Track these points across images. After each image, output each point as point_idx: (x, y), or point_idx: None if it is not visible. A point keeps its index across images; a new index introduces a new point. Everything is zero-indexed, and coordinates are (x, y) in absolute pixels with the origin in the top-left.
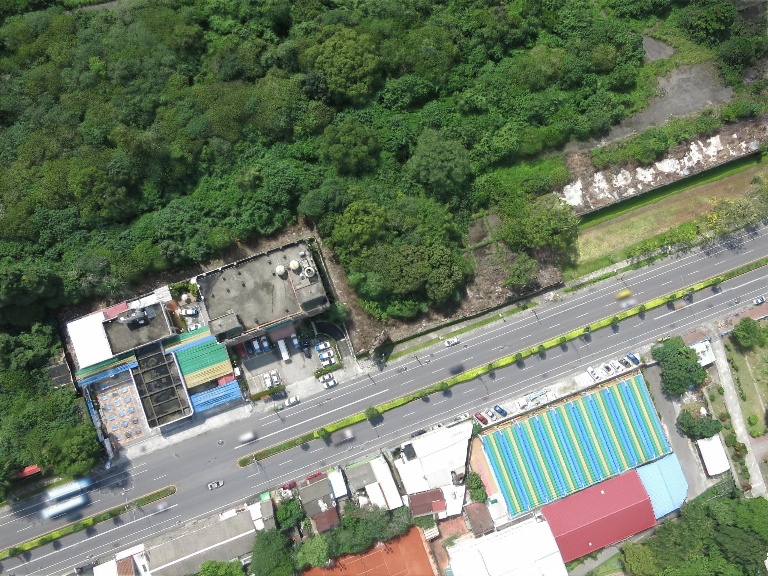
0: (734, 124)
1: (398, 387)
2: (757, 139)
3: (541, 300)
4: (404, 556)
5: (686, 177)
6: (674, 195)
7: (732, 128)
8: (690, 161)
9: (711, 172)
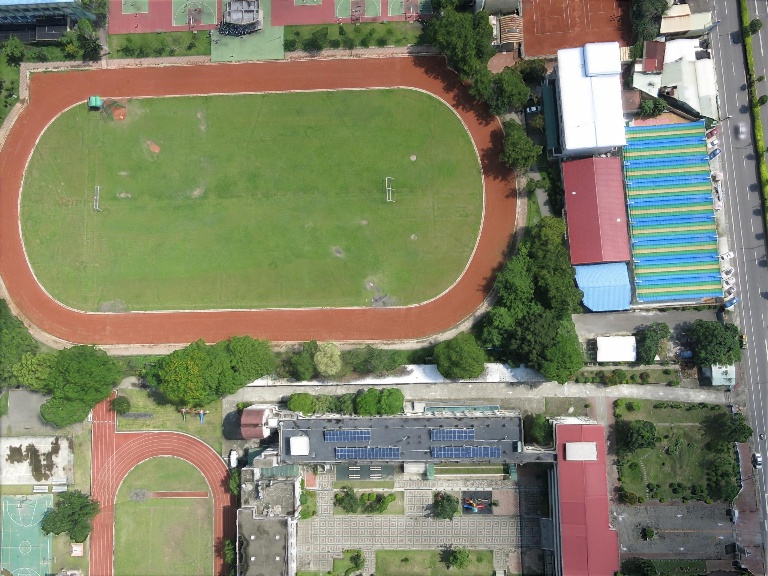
0: None
1: (763, 65)
2: None
3: None
4: (604, 30)
5: None
6: None
7: None
8: None
9: None
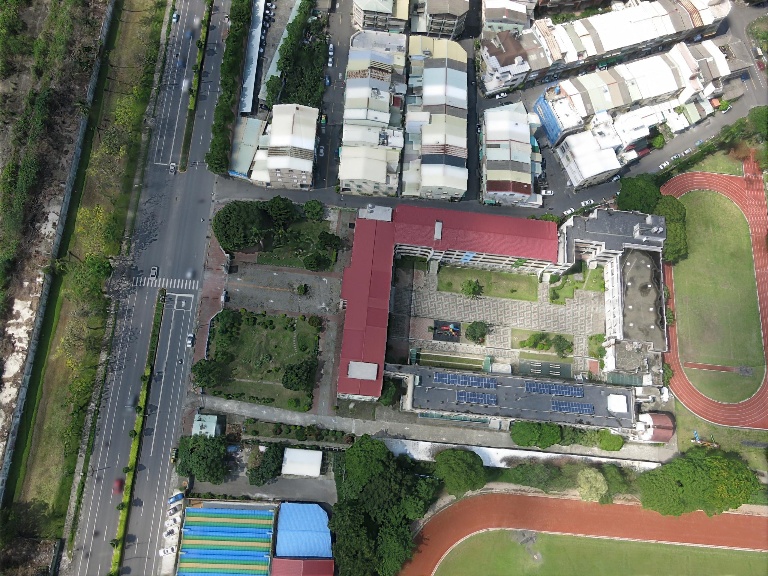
0: (11, 282)
1: None
2: (42, 264)
3: (64, 574)
4: None
5: (34, 354)
6: (46, 373)
7: (14, 285)
8: (22, 341)
9: (46, 325)
